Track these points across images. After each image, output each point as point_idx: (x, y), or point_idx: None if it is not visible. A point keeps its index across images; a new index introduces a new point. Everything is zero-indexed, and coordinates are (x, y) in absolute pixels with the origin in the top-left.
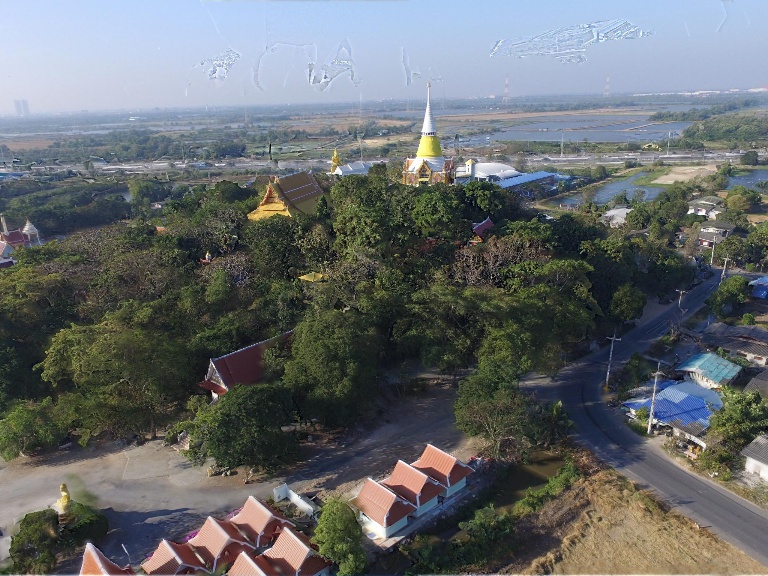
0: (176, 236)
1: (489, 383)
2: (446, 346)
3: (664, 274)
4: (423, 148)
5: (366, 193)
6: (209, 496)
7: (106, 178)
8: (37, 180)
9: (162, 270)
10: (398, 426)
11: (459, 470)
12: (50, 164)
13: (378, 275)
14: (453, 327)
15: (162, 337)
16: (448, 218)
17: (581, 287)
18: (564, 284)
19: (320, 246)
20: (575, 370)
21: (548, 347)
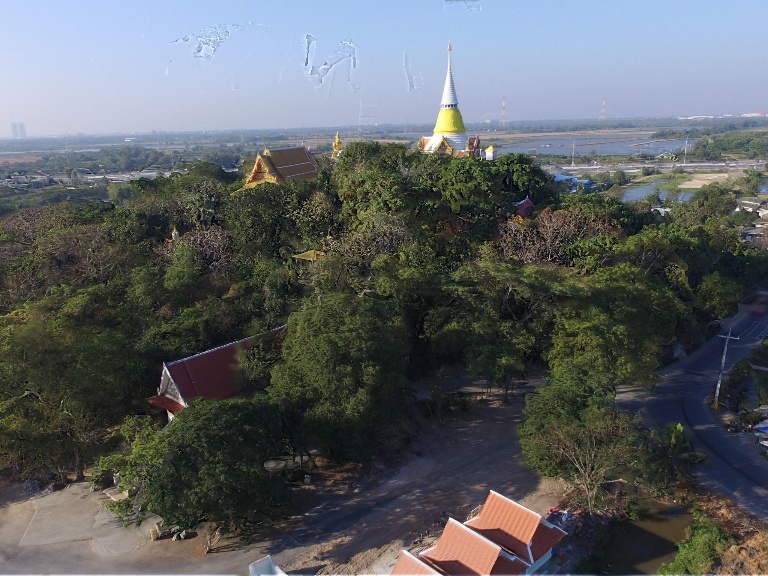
0: (135, 211)
1: (573, 397)
2: (502, 345)
3: (743, 267)
4: (442, 123)
5: (378, 163)
6: (148, 575)
7: (89, 186)
8: (14, 187)
9: (108, 246)
10: (434, 460)
11: (544, 534)
12: (31, 173)
13: (403, 248)
14: (510, 319)
15: (101, 334)
16: (487, 185)
17: (676, 268)
18: (650, 265)
19: (321, 219)
20: (663, 382)
21: (644, 347)
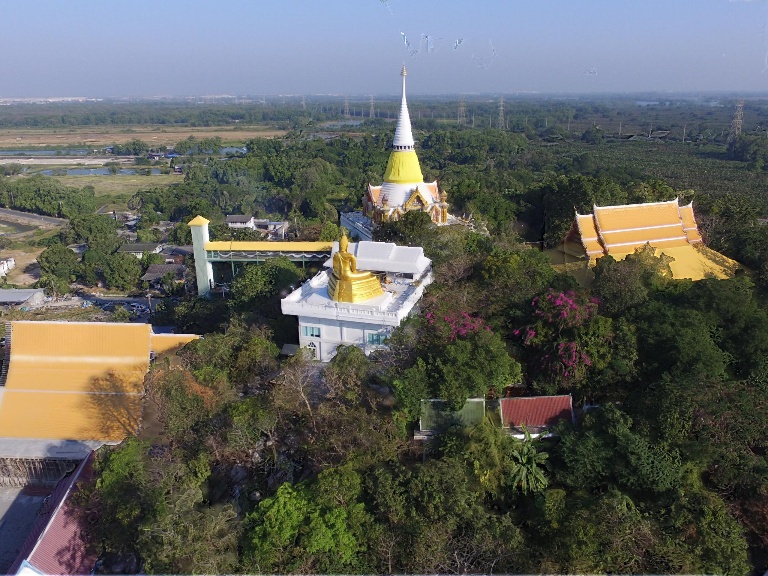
0: None
1: None
2: None
3: None
4: None
5: None
6: None
7: None
8: None
9: None
10: None
11: None
12: None
13: None
14: None
15: None
16: None
17: None
18: None
19: None
20: None
21: None
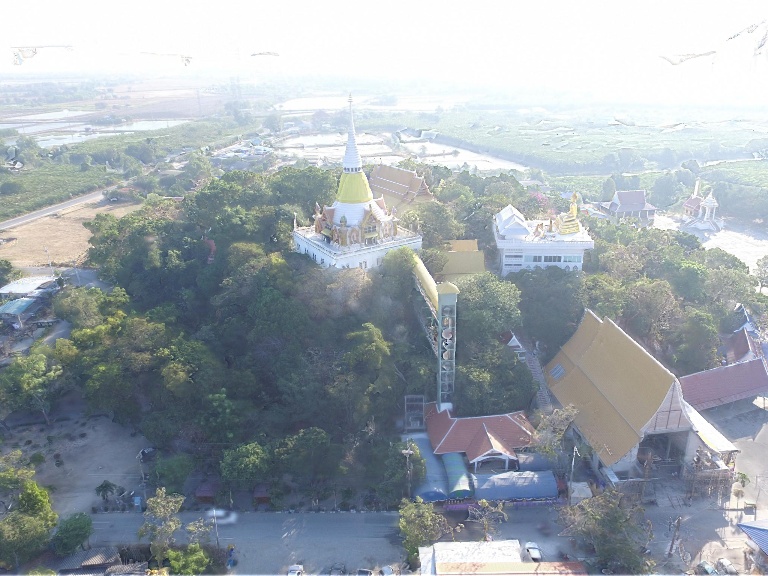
0: None
1: None
2: None
3: None
4: None
5: None
6: None
7: None
8: None
9: None
10: None
11: None
12: None
13: None
14: None
15: None
16: None
17: None
18: None
19: None
20: None
21: None
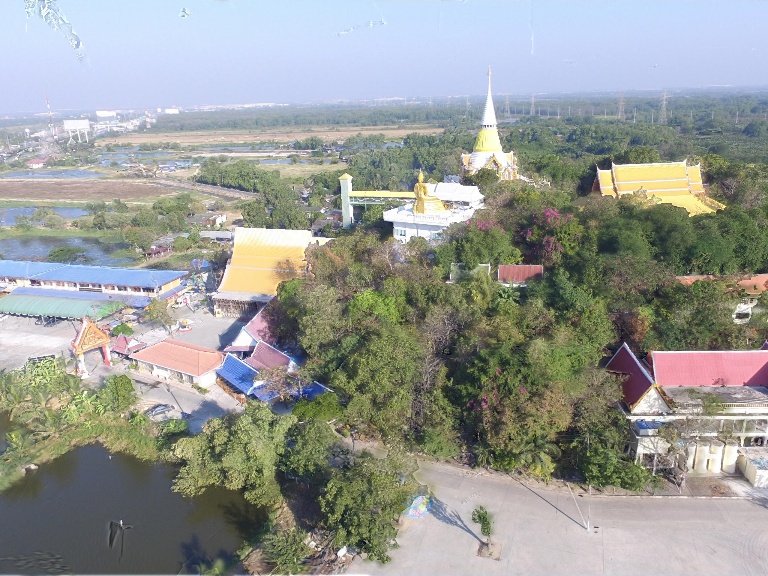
0: None
1: None
2: None
3: None
4: None
5: None
6: None
7: None
8: None
9: None
10: None
11: None
12: None
13: None
14: None
15: None
16: None
17: None
18: None
19: None
20: None
21: None
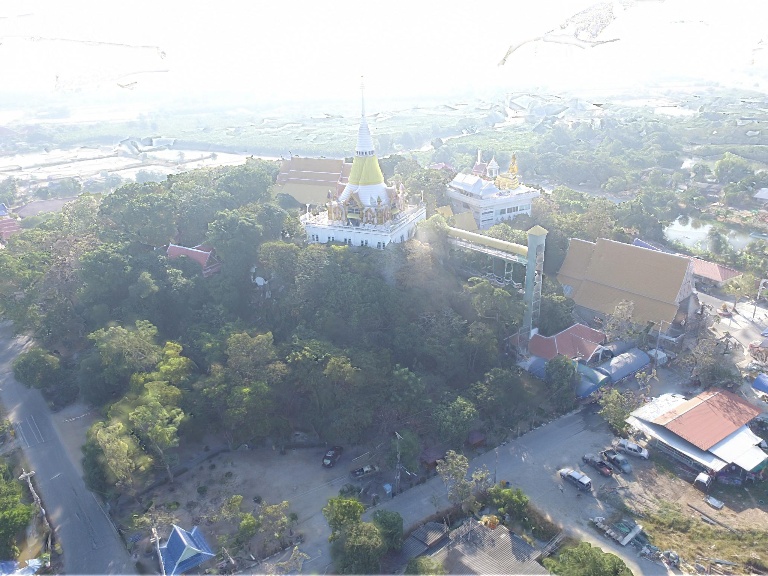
0: None
1: None
2: None
3: None
4: None
5: None
6: None
7: None
8: None
9: None
10: None
11: None
12: None
13: None
14: None
15: None
16: None
17: None
18: None
19: None
20: (18, 356)
21: None
